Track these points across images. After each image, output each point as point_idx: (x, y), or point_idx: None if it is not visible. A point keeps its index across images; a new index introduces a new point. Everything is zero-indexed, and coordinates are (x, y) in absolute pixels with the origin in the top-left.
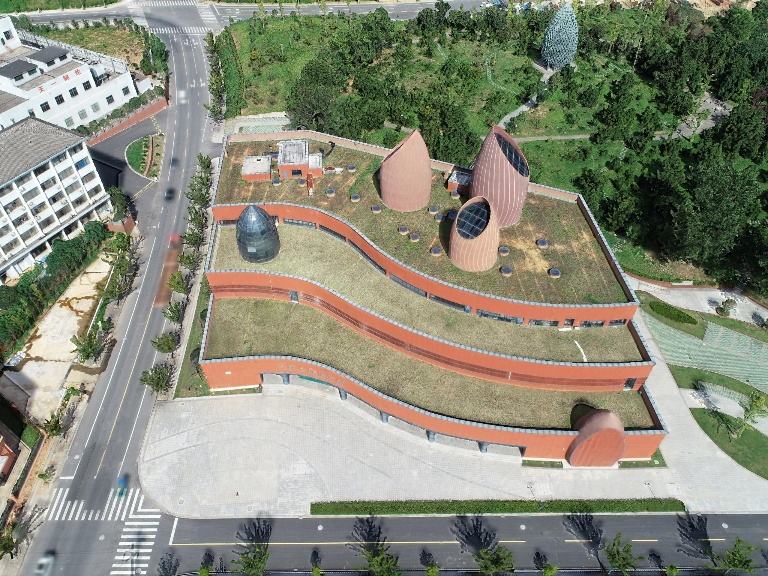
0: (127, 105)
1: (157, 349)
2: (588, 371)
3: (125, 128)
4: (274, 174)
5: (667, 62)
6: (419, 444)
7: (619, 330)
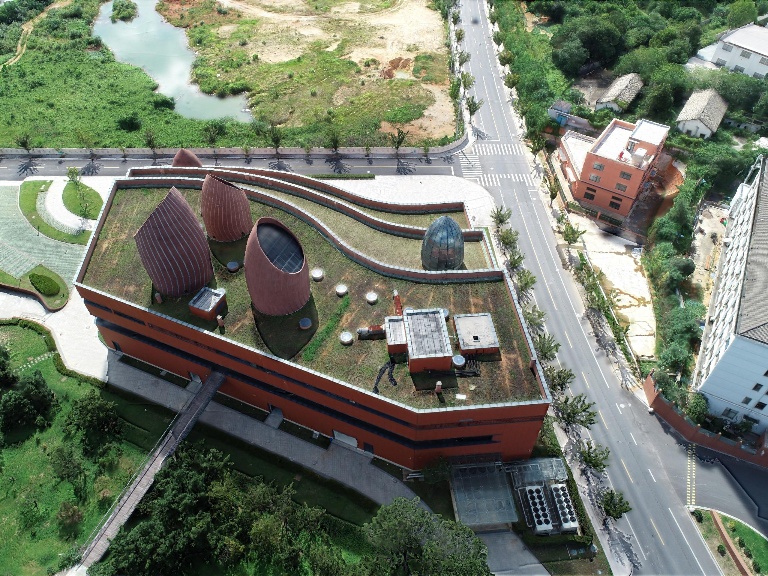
0: None
1: None
2: None
3: None
4: (451, 332)
5: None
6: None
7: None
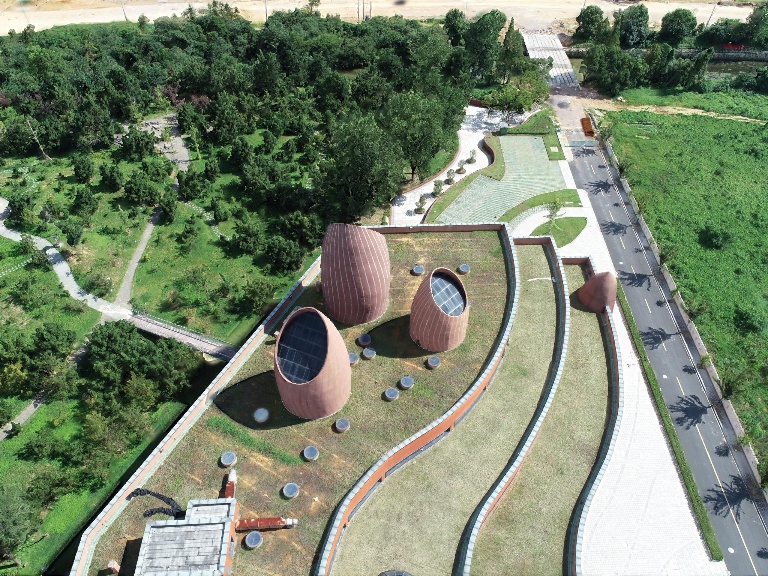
0: None
1: None
2: None
3: None
4: None
5: (85, 122)
6: None
7: None
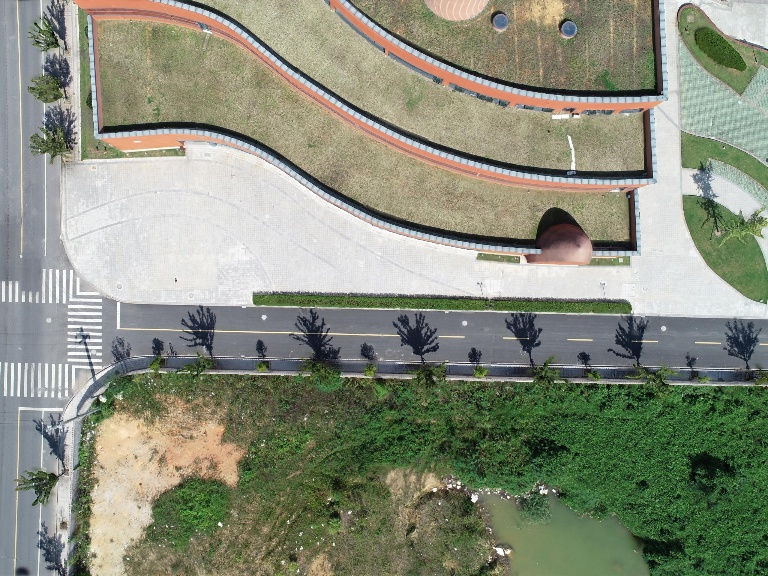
0: None
1: (40, 99)
2: (572, 184)
3: None
4: None
5: None
6: (368, 230)
7: (630, 120)
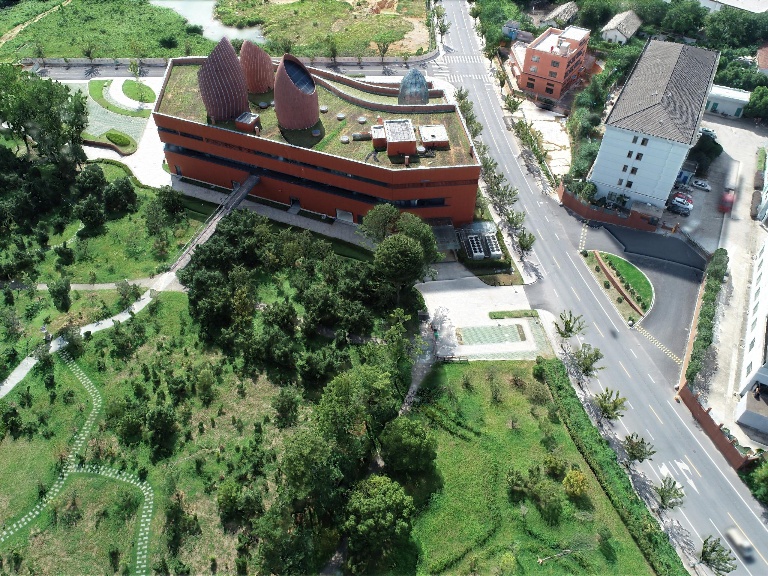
0: (704, 321)
1: None
2: None
3: None
4: (417, 137)
5: None
6: None
7: None
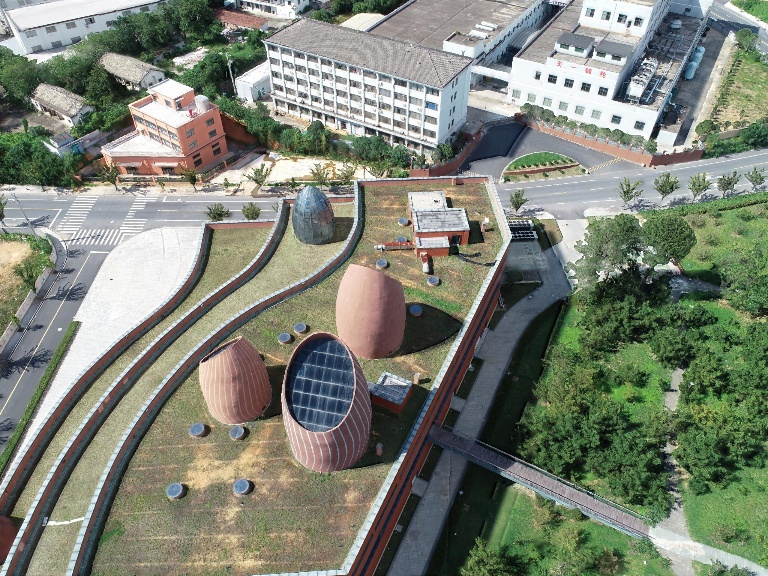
0: (605, 130)
1: None
2: None
3: (585, 145)
4: None
5: None
6: None
7: None
